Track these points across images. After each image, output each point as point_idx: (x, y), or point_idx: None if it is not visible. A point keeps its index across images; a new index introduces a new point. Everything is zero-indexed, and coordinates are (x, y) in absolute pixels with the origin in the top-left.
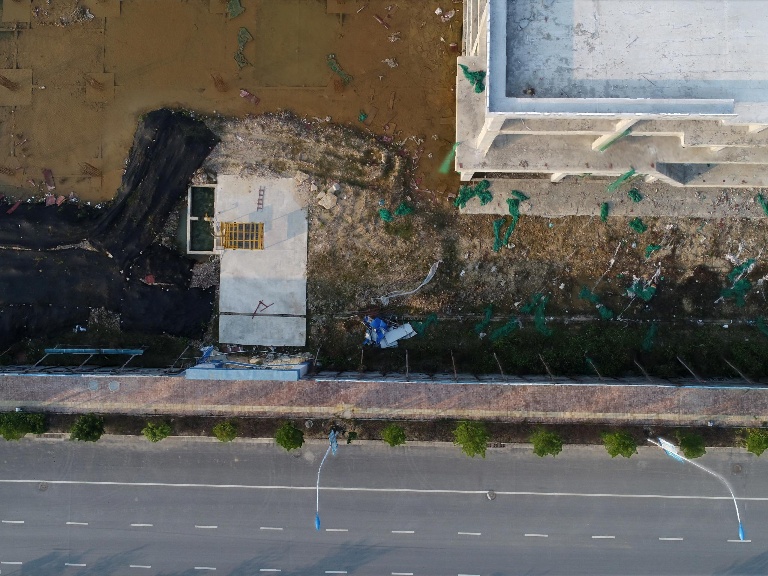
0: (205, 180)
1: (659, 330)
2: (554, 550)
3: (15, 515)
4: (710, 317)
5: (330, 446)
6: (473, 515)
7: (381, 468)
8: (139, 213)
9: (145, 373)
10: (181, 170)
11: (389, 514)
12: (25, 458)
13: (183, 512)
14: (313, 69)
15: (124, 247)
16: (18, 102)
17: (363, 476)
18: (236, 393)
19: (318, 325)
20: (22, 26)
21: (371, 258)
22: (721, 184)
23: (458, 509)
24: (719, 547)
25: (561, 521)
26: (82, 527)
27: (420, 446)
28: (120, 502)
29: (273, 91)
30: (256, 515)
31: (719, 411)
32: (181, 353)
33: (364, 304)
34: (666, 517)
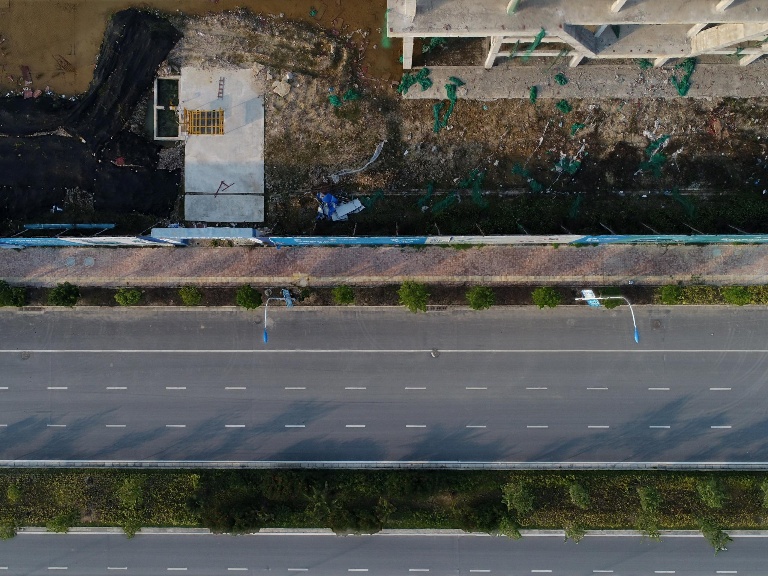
0: (170, 72)
1: (584, 200)
2: (492, 401)
3: None
4: (630, 188)
5: (284, 298)
6: (419, 372)
7: (335, 331)
8: (109, 102)
9: None
10: (147, 63)
11: (342, 373)
12: (8, 330)
13: (154, 375)
14: None
15: (96, 133)
16: None
17: (318, 339)
18: (201, 266)
19: (275, 202)
20: None
21: (322, 140)
22: (629, 53)
23: (405, 366)
24: (641, 395)
25: (498, 375)
26: (62, 391)
27: (370, 310)
28: (96, 368)
29: None
30: (221, 376)
31: (639, 272)
32: (150, 230)
33: (317, 182)
34: (593, 369)
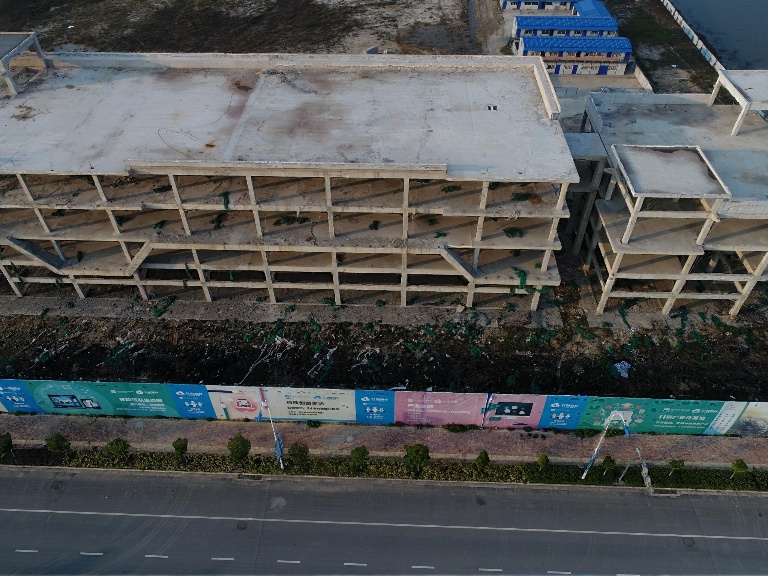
0: None
1: None
2: None
3: None
4: (89, 376)
5: None
6: None
7: None
8: None
9: None
10: None
11: None
12: None
13: None
14: None
15: None
16: None
17: None
18: None
19: None
20: None
21: None
22: (82, 270)
23: None
24: (4, 557)
25: None
26: None
27: None
28: None
29: None
30: None
31: None
32: None
33: None
34: None
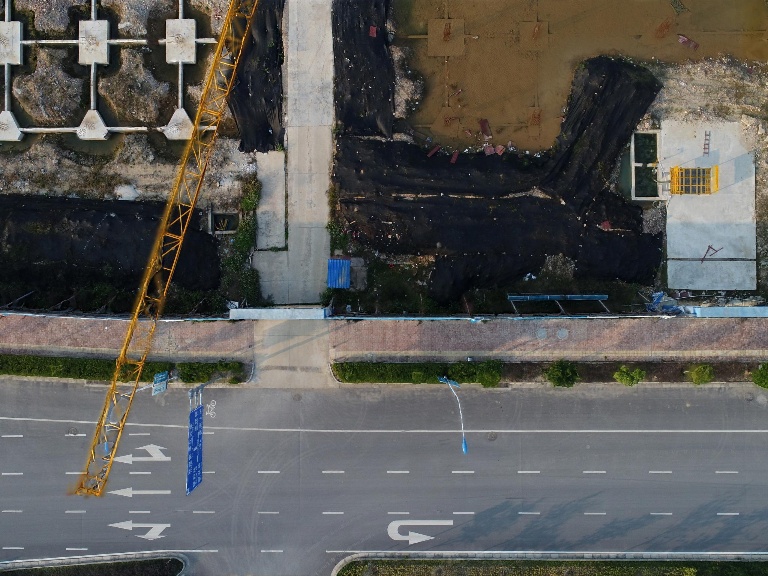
0: (650, 126)
1: None
2: None
3: (465, 465)
4: None
5: None
6: None
7: None
8: (589, 160)
9: (642, 314)
10: (627, 116)
11: None
12: (473, 408)
13: (636, 458)
14: (751, 13)
15: (576, 194)
16: (451, 52)
17: None
18: (687, 338)
19: (767, 268)
20: None
21: None
22: None
23: None
24: None
25: None
26: (534, 476)
27: None
28: (572, 450)
29: (711, 36)
30: (711, 459)
31: None
32: (630, 299)
33: None
34: None
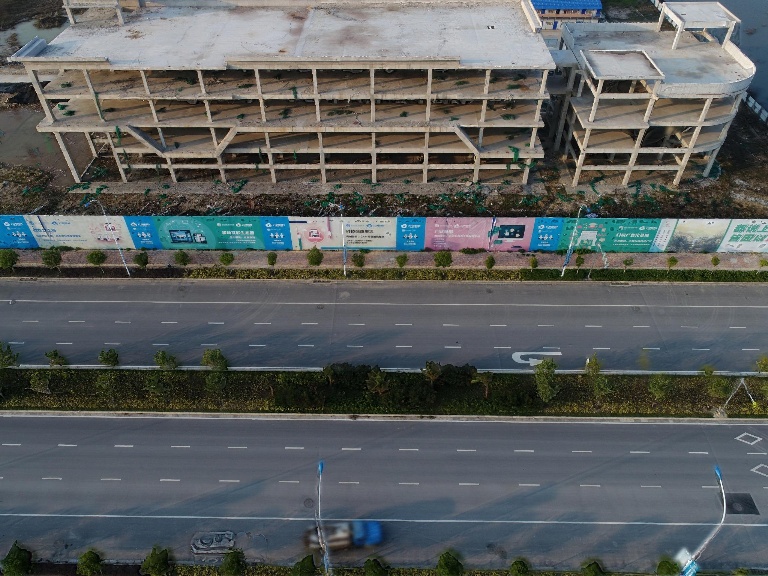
0: None
1: None
2: (38, 328)
3: None
4: None
5: None
6: None
7: None
8: None
9: None
10: None
11: None
12: None
13: None
14: (24, 152)
15: None
16: None
17: None
18: None
19: None
20: None
21: (6, 205)
22: (181, 153)
23: None
24: (154, 326)
25: (52, 314)
26: None
27: None
28: None
29: None
30: None
31: None
32: None
33: None
34: (125, 311)
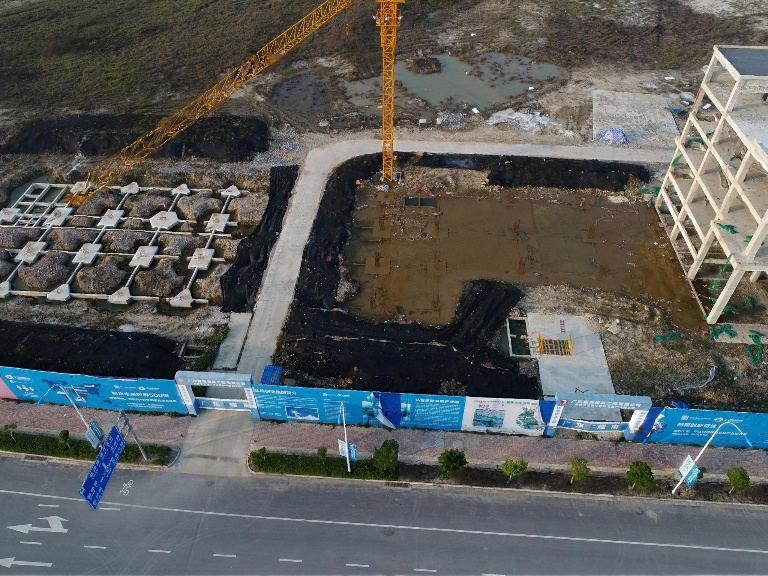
0: (519, 314)
1: None
2: None
3: (360, 558)
4: None
5: (693, 462)
6: None
7: (727, 529)
8: (474, 328)
9: None
10: (501, 307)
11: (753, 575)
12: (373, 503)
13: (536, 563)
14: (581, 266)
15: (465, 346)
16: (380, 272)
17: (712, 535)
18: (570, 455)
19: None
20: (385, 240)
21: (659, 364)
22: None
23: None
24: None
25: None
26: (430, 575)
27: (757, 510)
28: (469, 550)
29: (556, 274)
30: (613, 570)
31: None
32: None
33: (663, 394)
34: None
